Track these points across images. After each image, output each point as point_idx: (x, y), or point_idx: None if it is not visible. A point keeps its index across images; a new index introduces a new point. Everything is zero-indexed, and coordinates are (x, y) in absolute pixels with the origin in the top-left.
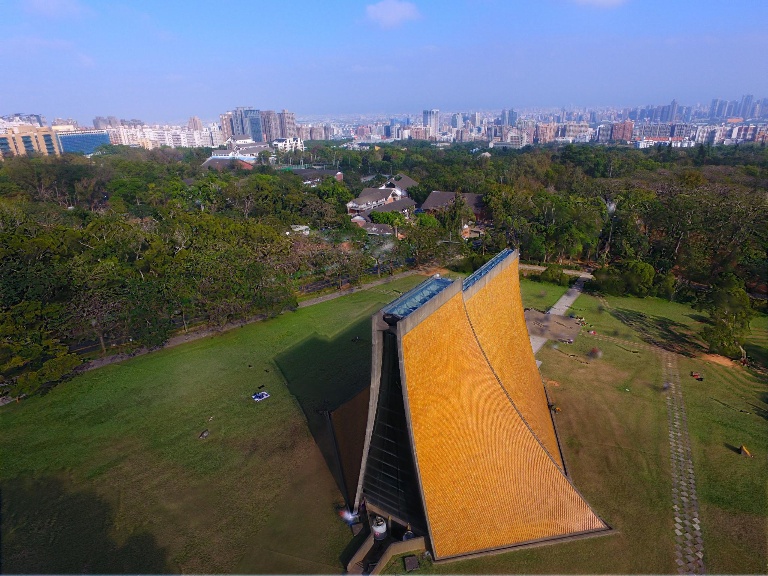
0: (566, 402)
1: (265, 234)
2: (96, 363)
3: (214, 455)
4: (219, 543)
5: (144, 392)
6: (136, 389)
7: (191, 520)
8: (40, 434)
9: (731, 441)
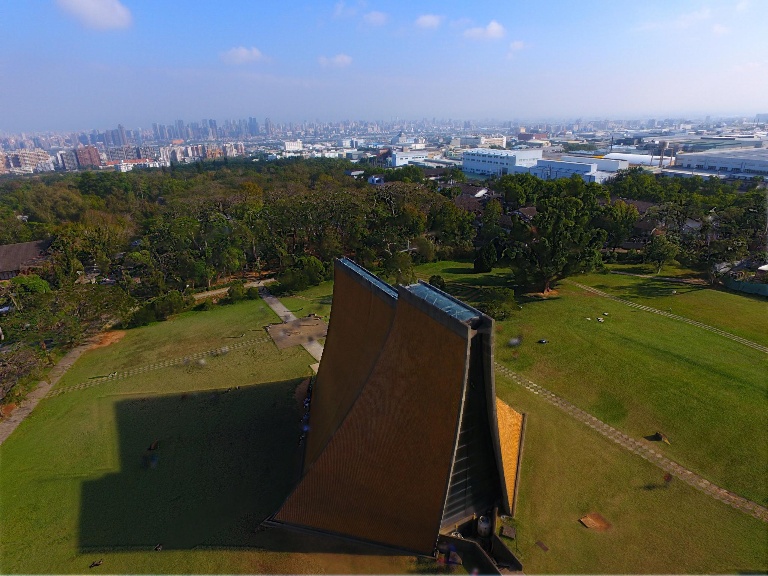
0: None
1: None
2: None
3: None
4: None
5: None
6: None
7: None
8: None
9: None
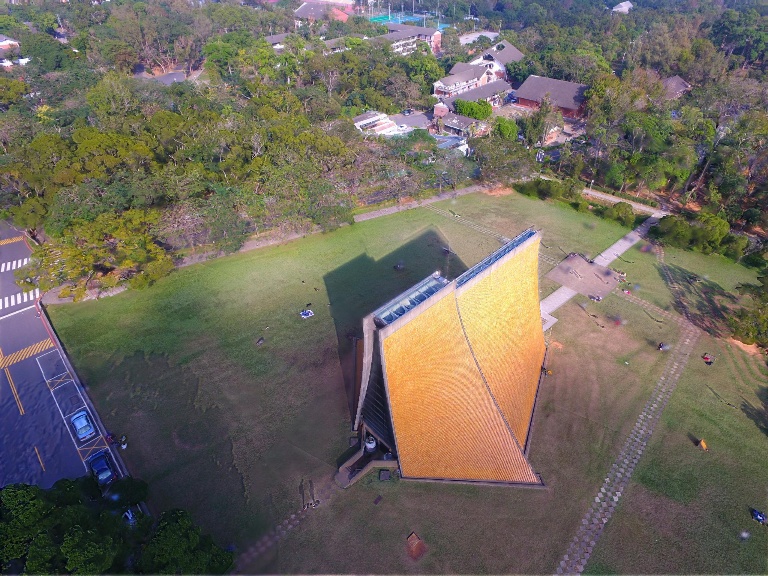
0: (560, 367)
1: (331, 147)
2: (187, 260)
3: (265, 361)
4: (259, 432)
5: (220, 295)
6: (215, 291)
7: (243, 411)
8: (148, 321)
9: (696, 432)
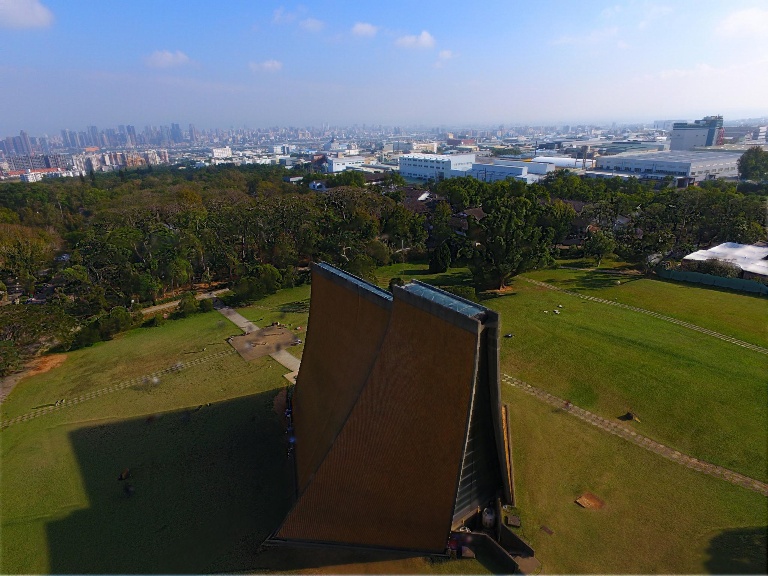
0: None
1: None
2: None
3: None
4: None
5: None
6: None
7: None
8: None
9: None
